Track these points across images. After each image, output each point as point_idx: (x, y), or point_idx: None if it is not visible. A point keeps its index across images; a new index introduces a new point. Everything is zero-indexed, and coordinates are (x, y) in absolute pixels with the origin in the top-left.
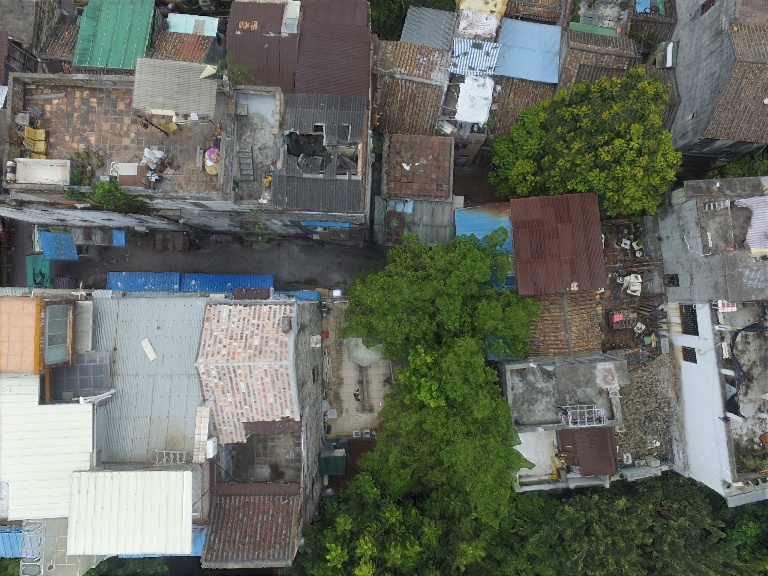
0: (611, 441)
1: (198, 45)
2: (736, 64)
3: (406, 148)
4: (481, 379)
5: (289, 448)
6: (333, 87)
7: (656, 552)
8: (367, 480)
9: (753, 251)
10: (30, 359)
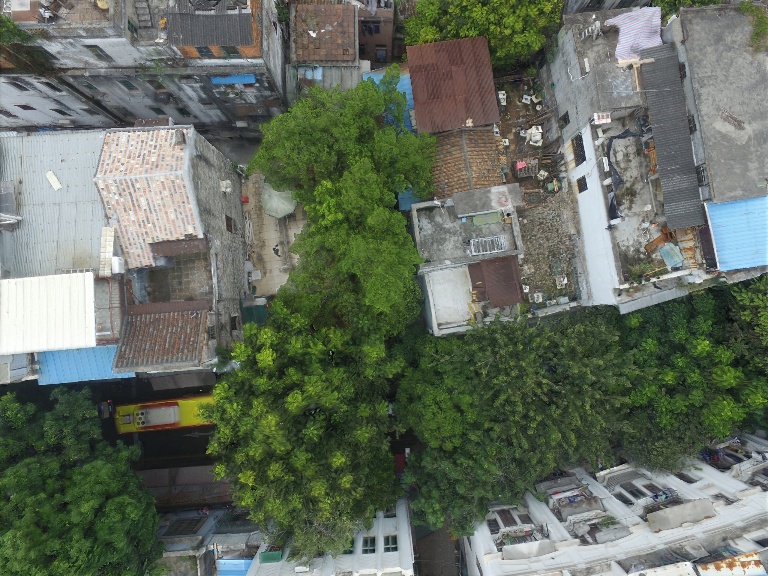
0: (516, 272)
1: None
2: None
3: (311, 16)
4: (376, 194)
5: (203, 282)
6: None
7: (555, 358)
8: None
9: (620, 61)
10: None
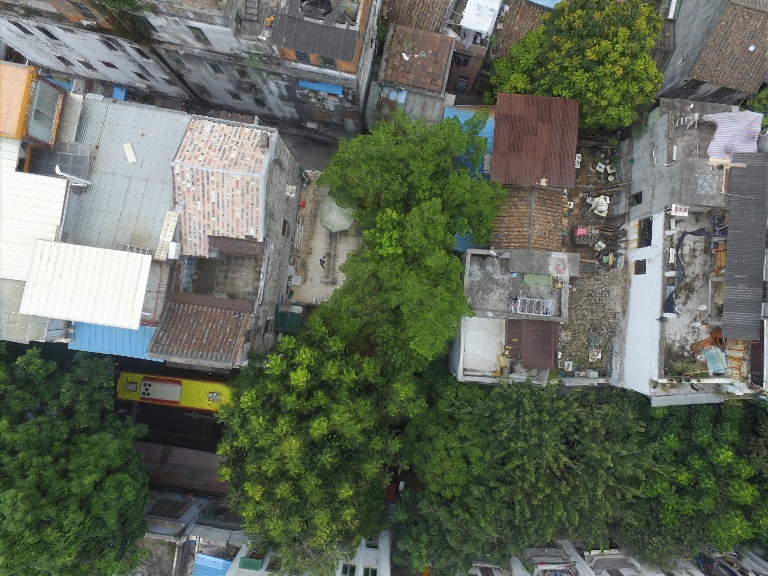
0: (554, 338)
1: None
2: (729, 6)
3: (408, 39)
4: (440, 236)
5: (249, 282)
6: None
7: (577, 435)
8: (318, 322)
9: (711, 160)
10: (14, 123)
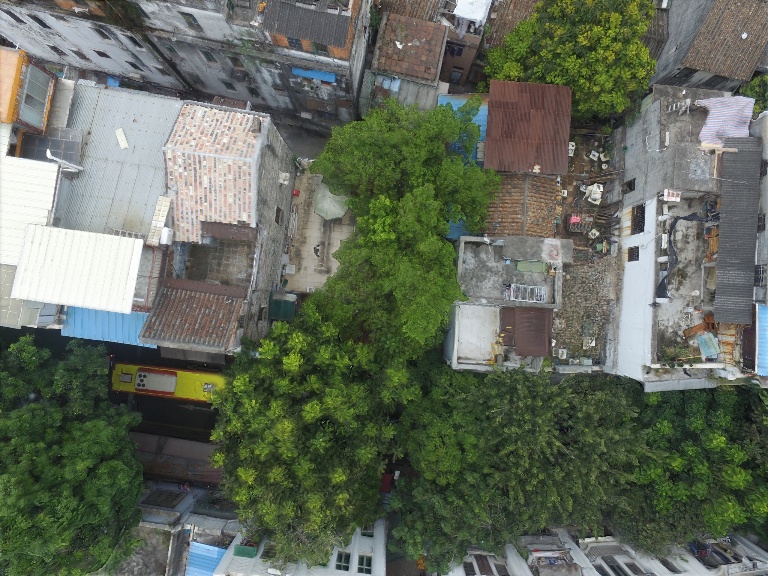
0: (548, 325)
1: None
2: None
3: (402, 27)
4: (433, 221)
5: (242, 268)
6: None
7: (571, 421)
8: (311, 309)
9: (703, 144)
10: (5, 107)
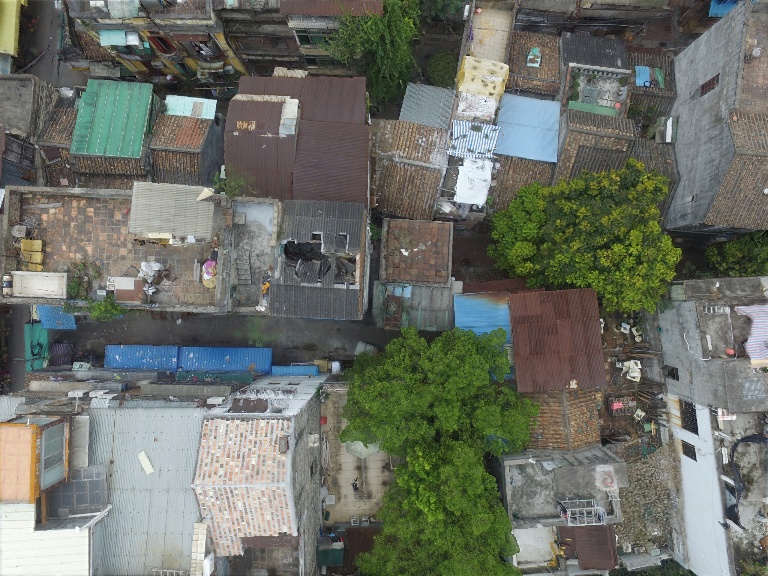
0: (610, 536)
1: (196, 129)
2: (736, 156)
3: (405, 234)
4: (479, 491)
5: (287, 552)
6: (331, 186)
7: None
8: None
9: (753, 362)
10: (26, 487)
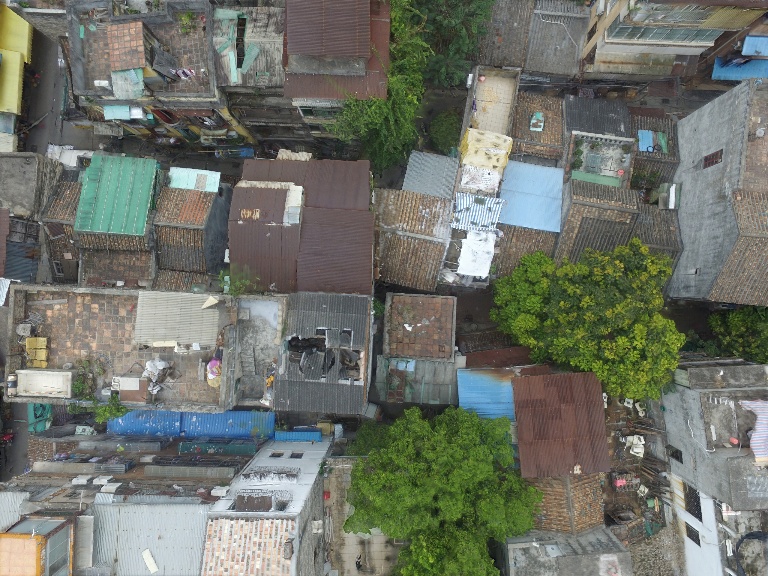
0: None
1: (200, 204)
2: (740, 238)
3: (408, 309)
4: None
5: None
6: (335, 273)
7: None
8: None
9: (757, 459)
10: None
